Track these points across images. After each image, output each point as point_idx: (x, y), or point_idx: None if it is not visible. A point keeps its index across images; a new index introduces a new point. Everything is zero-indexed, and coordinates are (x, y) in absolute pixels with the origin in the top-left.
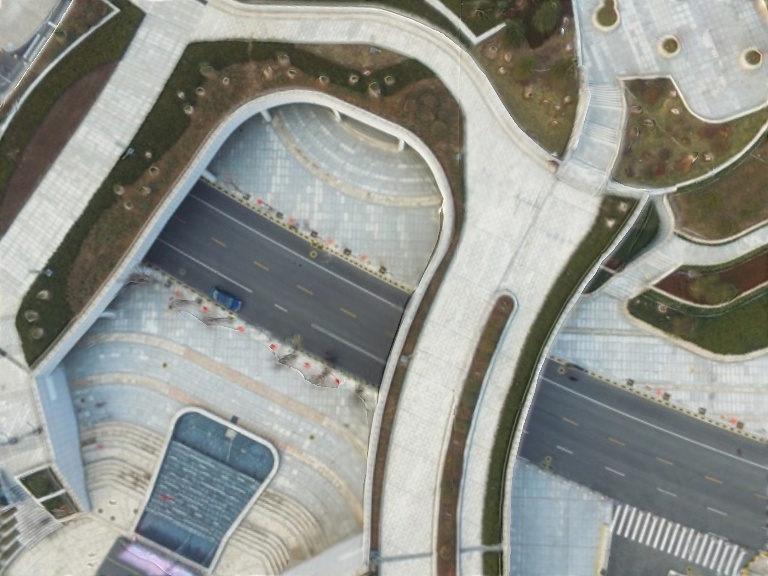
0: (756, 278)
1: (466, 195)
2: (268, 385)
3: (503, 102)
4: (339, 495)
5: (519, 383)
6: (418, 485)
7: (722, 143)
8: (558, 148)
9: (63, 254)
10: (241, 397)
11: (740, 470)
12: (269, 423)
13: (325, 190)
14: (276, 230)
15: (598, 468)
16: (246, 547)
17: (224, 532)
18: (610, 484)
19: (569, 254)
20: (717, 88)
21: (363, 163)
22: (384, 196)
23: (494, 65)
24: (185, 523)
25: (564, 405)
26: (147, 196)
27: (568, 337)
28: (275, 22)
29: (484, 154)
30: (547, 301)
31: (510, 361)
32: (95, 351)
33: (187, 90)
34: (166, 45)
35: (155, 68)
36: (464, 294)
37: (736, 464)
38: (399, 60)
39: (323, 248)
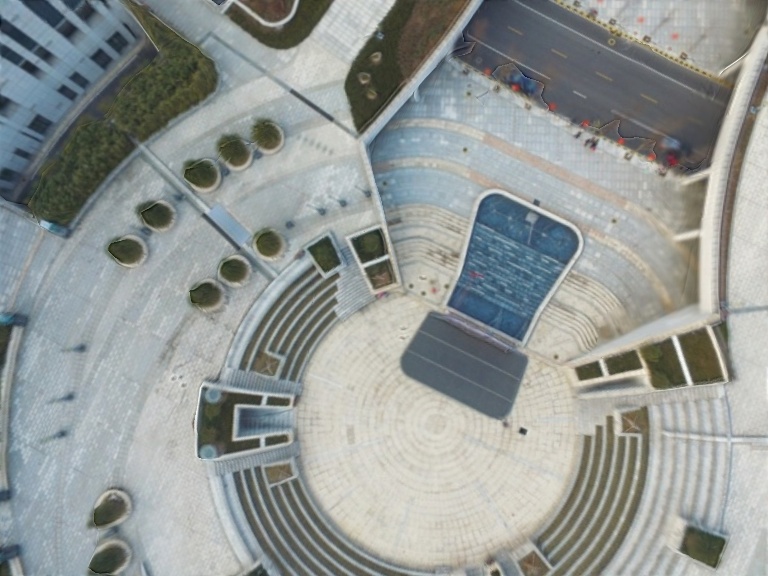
0: None
1: None
2: (569, 169)
3: None
4: (643, 278)
5: None
6: (765, 238)
7: None
8: None
9: (395, 17)
10: (542, 181)
11: None
12: (571, 207)
13: None
14: (573, 18)
15: None
16: (557, 323)
17: (536, 307)
18: None
19: None
20: None
21: None
22: None
23: None
24: (496, 298)
25: None
26: None
27: None
28: None
29: None
30: None
31: None
32: (397, 135)
33: None
34: None
35: None
36: None
37: None
38: None
39: (622, 35)
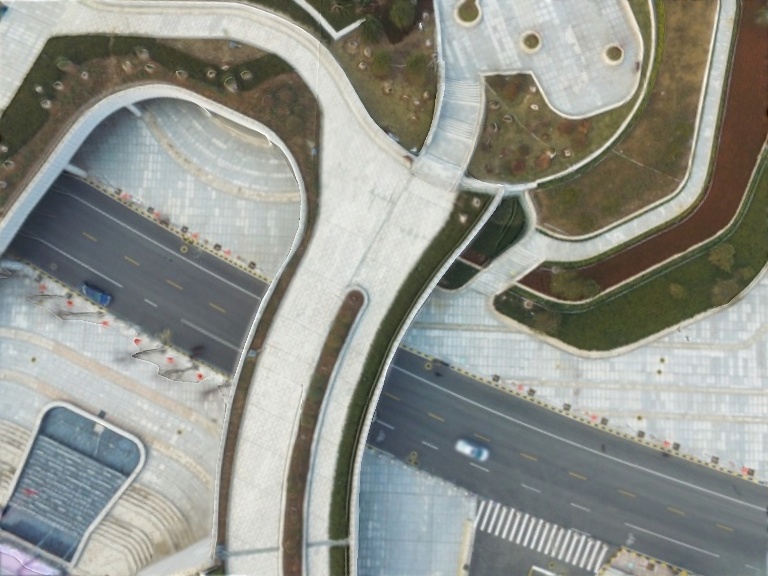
0: (620, 274)
1: (320, 190)
2: (136, 380)
3: (363, 97)
4: (206, 490)
5: (367, 378)
6: (266, 480)
7: (581, 139)
8: (418, 143)
9: None
10: (109, 392)
11: (604, 466)
12: (137, 418)
13: (196, 185)
14: (147, 225)
15: (463, 464)
16: (109, 541)
17: (87, 526)
18: (475, 480)
19: (422, 249)
20: (579, 84)
21: (234, 158)
22: (255, 191)
23: (355, 60)
24: (48, 517)
25: (430, 401)
26: (2, 190)
27: (435, 333)
28: (137, 17)
29: (340, 149)
30: (398, 296)
31: (359, 356)
32: None
33: (45, 84)
34: (27, 39)
35: (15, 62)
36: (315, 289)
37: (600, 460)
38: (259, 55)
39: (193, 243)
